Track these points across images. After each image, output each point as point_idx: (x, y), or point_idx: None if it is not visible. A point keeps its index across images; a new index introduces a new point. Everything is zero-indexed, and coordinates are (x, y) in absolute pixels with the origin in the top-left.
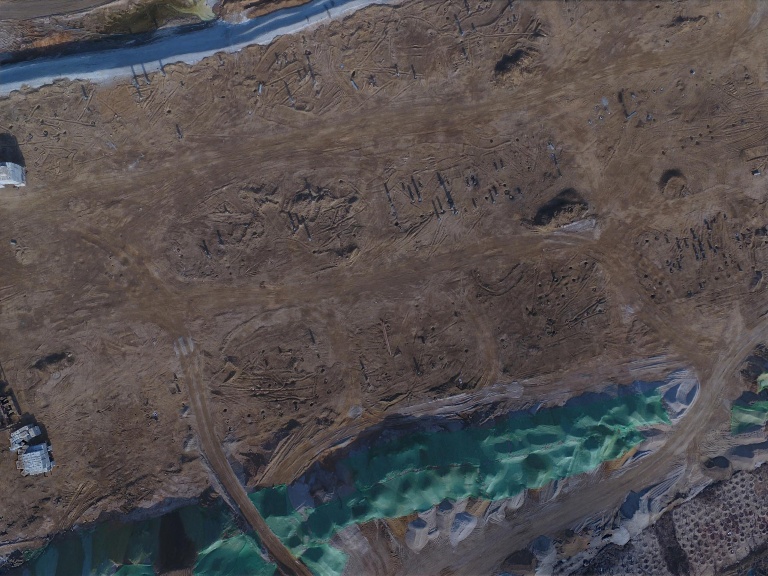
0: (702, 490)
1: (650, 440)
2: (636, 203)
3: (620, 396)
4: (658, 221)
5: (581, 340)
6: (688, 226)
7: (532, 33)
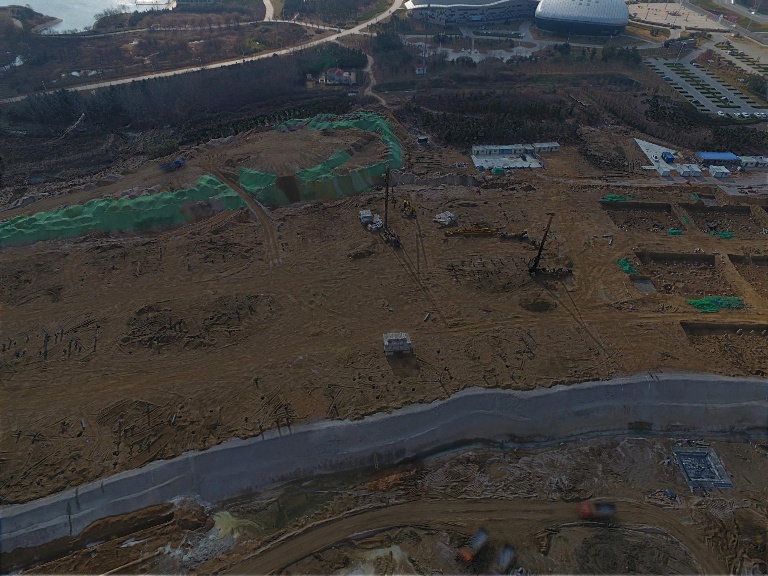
0: None
1: None
2: None
3: None
4: None
5: (3, 269)
6: None
7: None
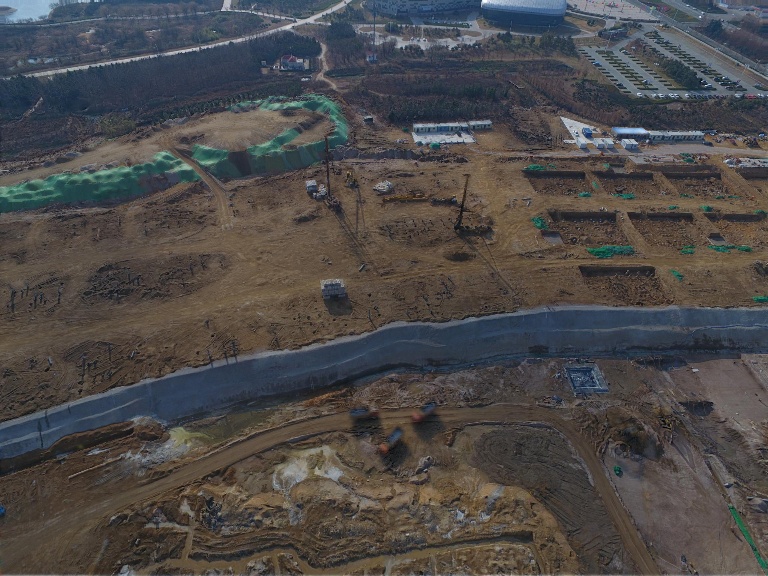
0: None
1: None
2: None
3: None
4: None
5: None
6: None
7: None
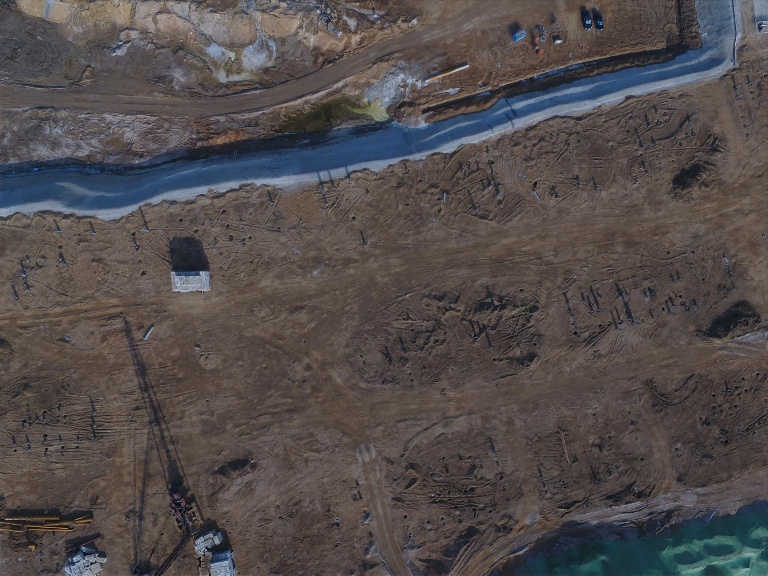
0: None
1: None
2: None
3: None
4: None
5: (752, 450)
6: None
7: (709, 147)
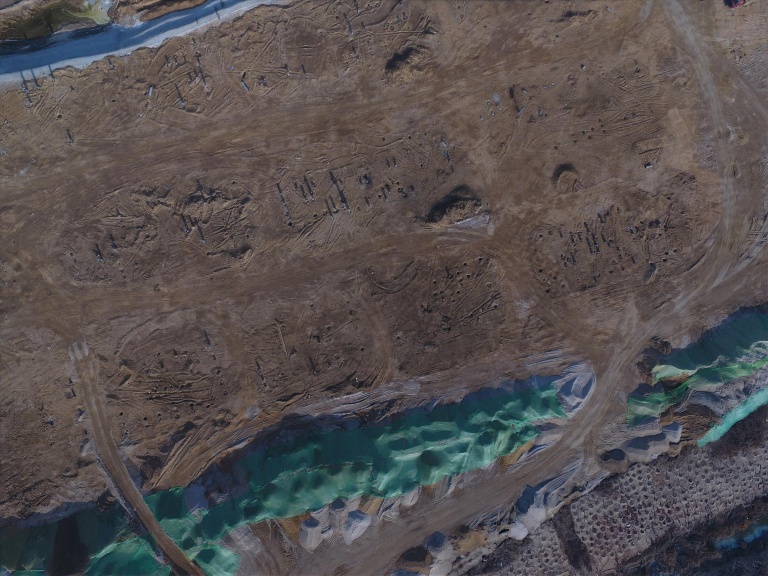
0: (599, 483)
1: (544, 434)
2: (529, 198)
3: (516, 391)
4: (552, 216)
5: (477, 336)
6: (582, 220)
7: (422, 31)
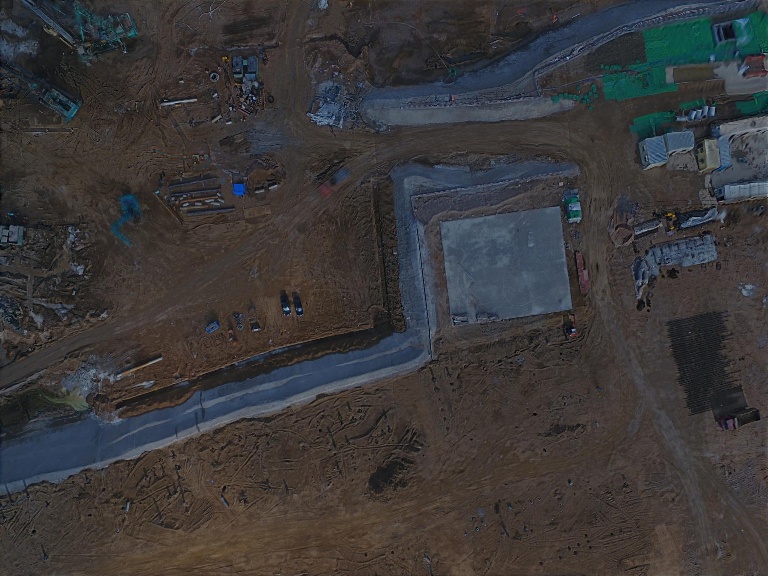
0: None
1: None
2: None
3: None
4: None
5: None
6: None
7: (407, 444)
